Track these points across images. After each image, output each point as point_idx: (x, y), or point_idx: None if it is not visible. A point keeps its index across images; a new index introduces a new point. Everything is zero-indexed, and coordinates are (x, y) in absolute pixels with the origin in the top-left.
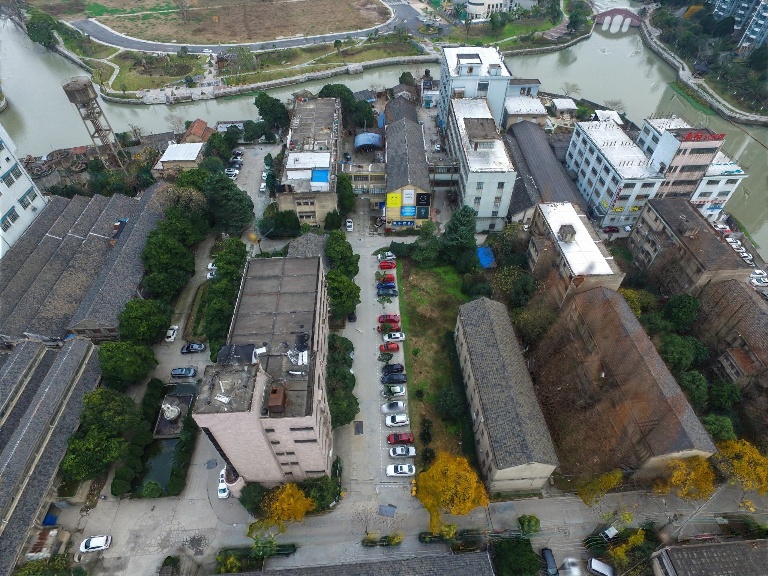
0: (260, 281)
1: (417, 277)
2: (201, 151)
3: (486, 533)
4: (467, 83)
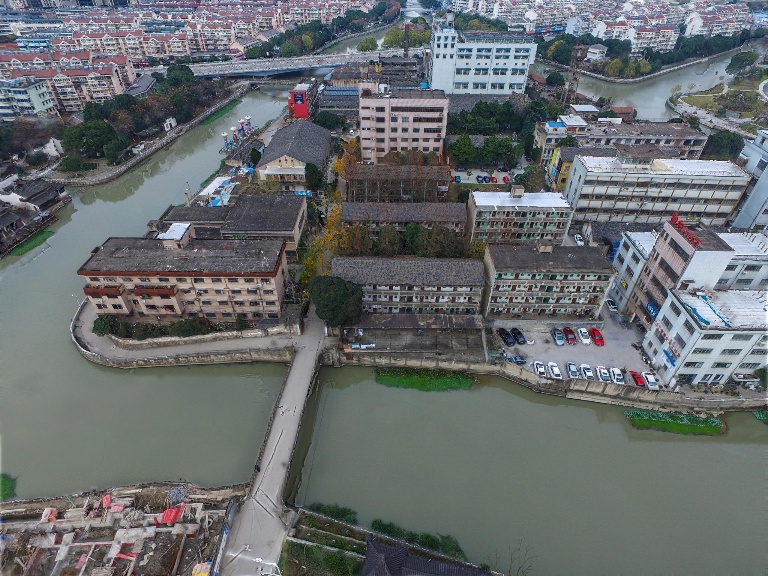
0: None
1: (499, 190)
2: (593, 114)
3: (327, 170)
4: (754, 154)
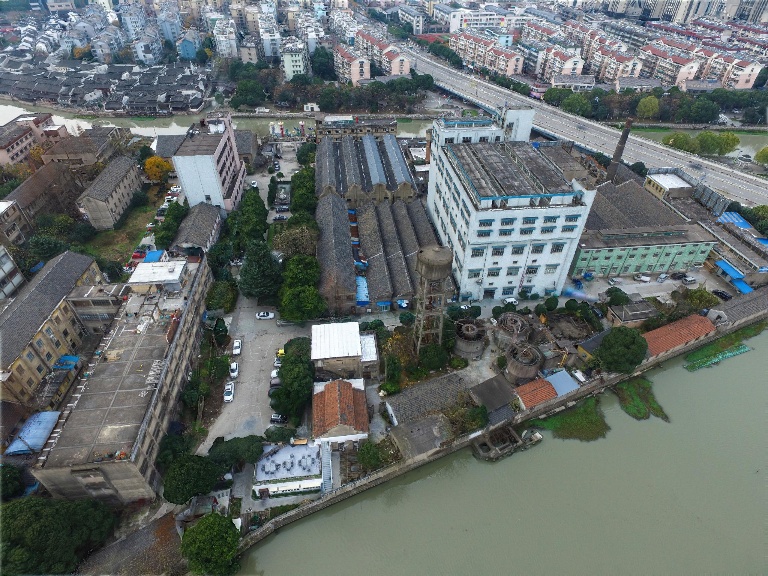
0: (208, 149)
1: None
2: None
3: None
4: None
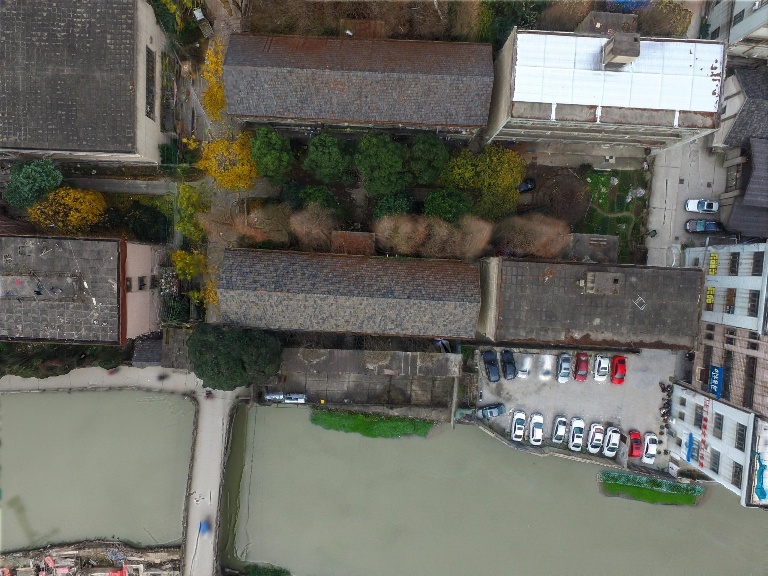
0: None
1: None
2: None
3: None
4: None
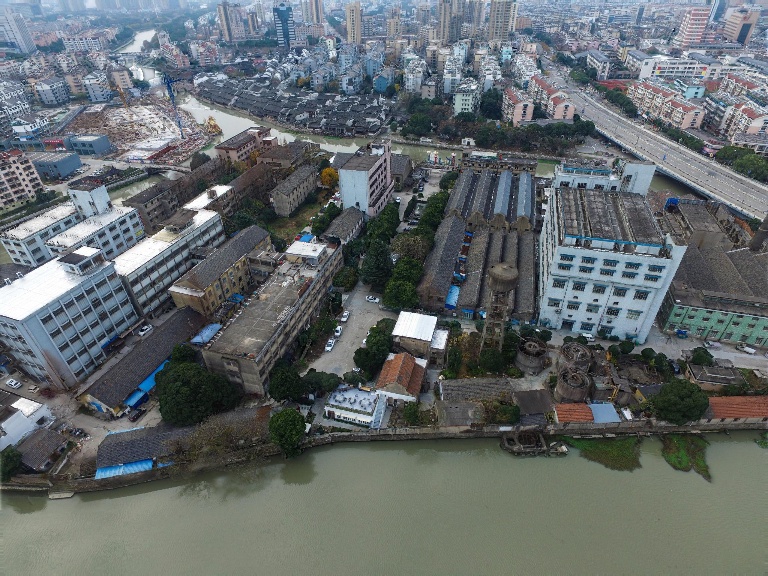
0: None
1: None
2: None
3: None
4: None
